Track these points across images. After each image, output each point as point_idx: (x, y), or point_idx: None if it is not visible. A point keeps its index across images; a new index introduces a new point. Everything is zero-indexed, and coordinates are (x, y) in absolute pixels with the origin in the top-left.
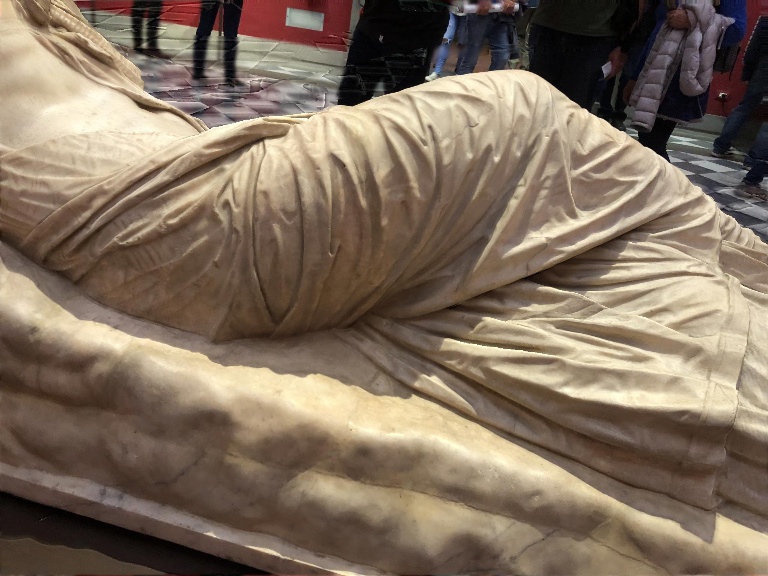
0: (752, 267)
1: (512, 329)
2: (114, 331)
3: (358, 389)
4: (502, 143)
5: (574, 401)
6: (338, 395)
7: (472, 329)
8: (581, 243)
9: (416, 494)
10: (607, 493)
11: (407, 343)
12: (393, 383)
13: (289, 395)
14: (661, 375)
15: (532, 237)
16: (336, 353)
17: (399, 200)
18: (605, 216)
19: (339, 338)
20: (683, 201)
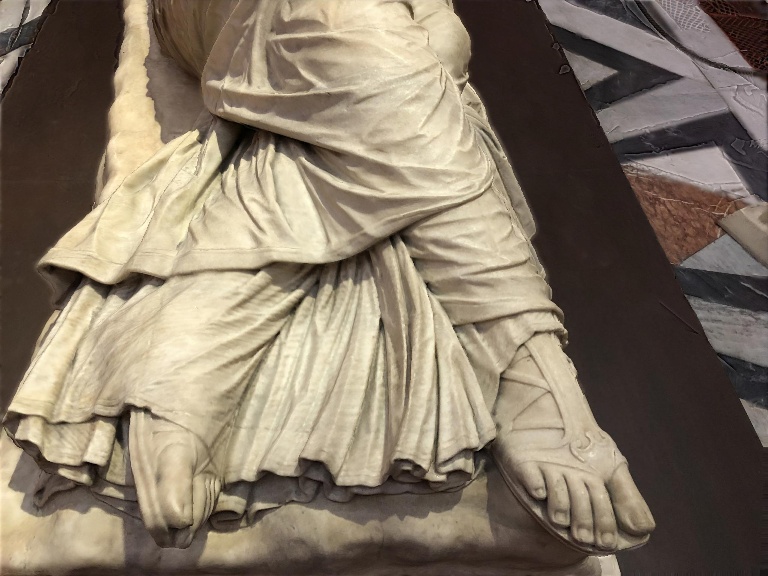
0: None
1: None
2: (145, 15)
3: (158, 127)
4: None
5: None
6: (143, 118)
7: None
8: (234, 109)
9: None
10: None
11: None
12: None
13: (126, 96)
14: (99, 220)
15: (225, 79)
16: (189, 104)
17: None
18: (255, 96)
19: None
20: (355, 150)
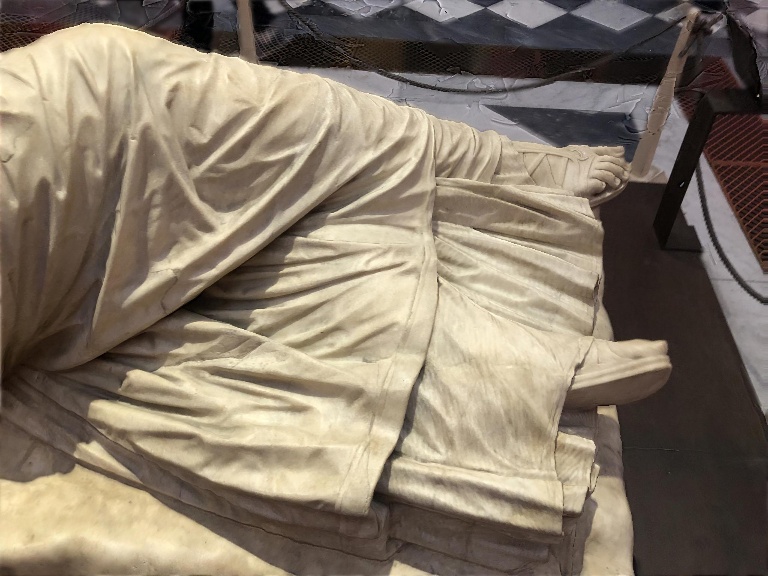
0: (482, 207)
1: (156, 388)
2: None
3: None
4: (62, 170)
5: (217, 484)
6: None
7: (120, 385)
8: (223, 264)
9: None
10: (275, 564)
11: (59, 404)
12: (53, 454)
13: None
14: (302, 448)
15: (157, 271)
16: None
17: None
18: (248, 222)
19: None
20: (371, 157)
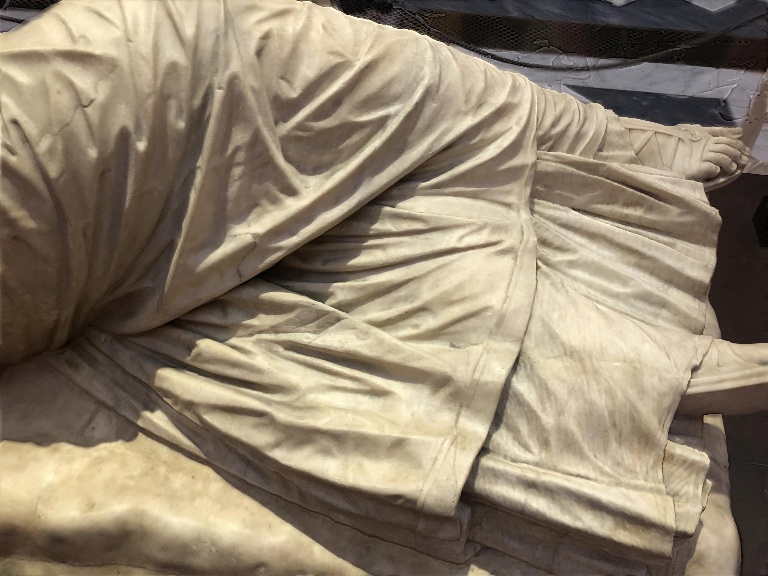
0: (585, 185)
1: (227, 360)
2: None
3: (61, 446)
4: (144, 119)
5: (287, 467)
6: (30, 465)
7: (189, 354)
8: (305, 231)
9: (134, 569)
10: (343, 556)
11: (125, 369)
12: (116, 420)
13: None
14: (383, 437)
15: (235, 234)
16: (40, 394)
17: (7, 237)
18: (335, 187)
19: (51, 366)
20: (470, 123)
